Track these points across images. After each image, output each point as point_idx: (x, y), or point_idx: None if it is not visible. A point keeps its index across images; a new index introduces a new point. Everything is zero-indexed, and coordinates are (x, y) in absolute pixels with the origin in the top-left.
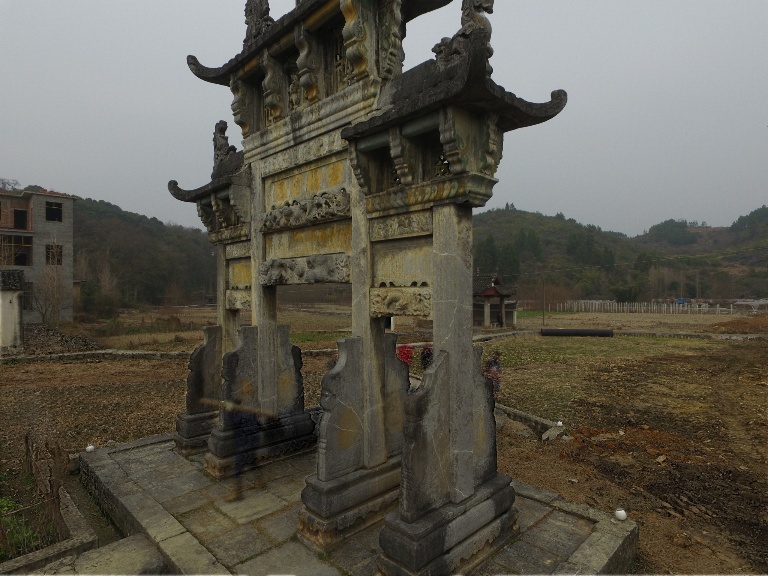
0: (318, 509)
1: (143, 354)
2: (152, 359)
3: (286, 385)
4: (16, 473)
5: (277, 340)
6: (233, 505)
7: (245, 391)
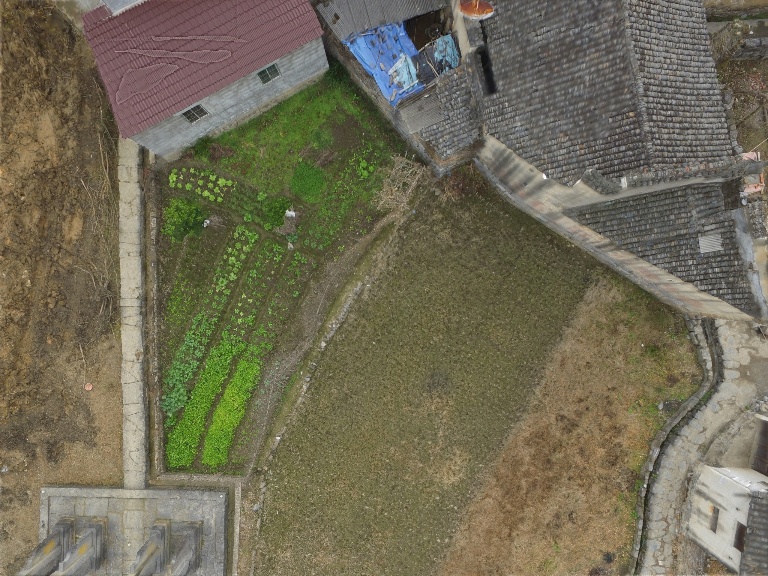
0: (92, 524)
1: None
2: None
3: None
4: (260, 470)
5: None
6: (136, 515)
7: None
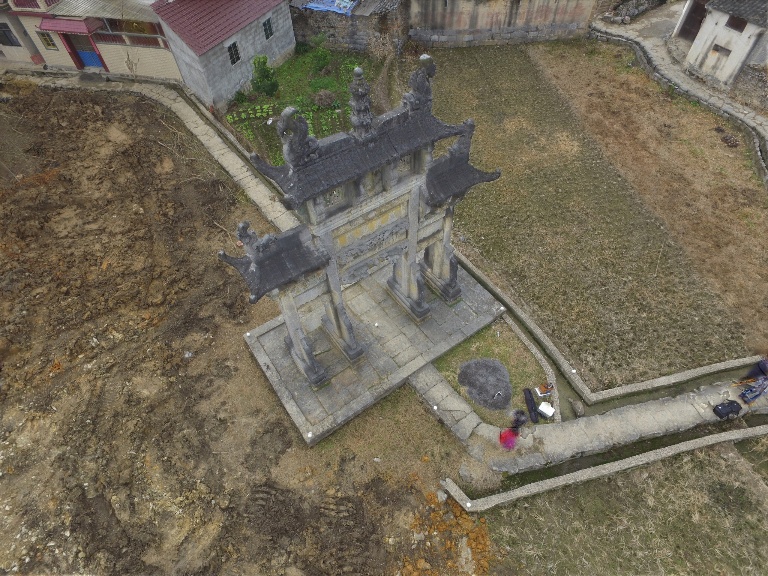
0: None
1: (762, 166)
2: (760, 177)
3: (414, 290)
4: None
5: (411, 270)
6: (361, 298)
7: (399, 274)
